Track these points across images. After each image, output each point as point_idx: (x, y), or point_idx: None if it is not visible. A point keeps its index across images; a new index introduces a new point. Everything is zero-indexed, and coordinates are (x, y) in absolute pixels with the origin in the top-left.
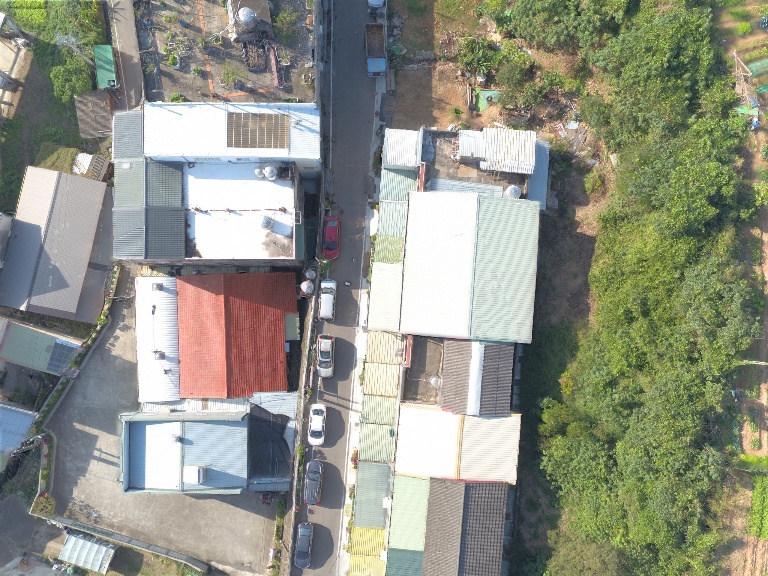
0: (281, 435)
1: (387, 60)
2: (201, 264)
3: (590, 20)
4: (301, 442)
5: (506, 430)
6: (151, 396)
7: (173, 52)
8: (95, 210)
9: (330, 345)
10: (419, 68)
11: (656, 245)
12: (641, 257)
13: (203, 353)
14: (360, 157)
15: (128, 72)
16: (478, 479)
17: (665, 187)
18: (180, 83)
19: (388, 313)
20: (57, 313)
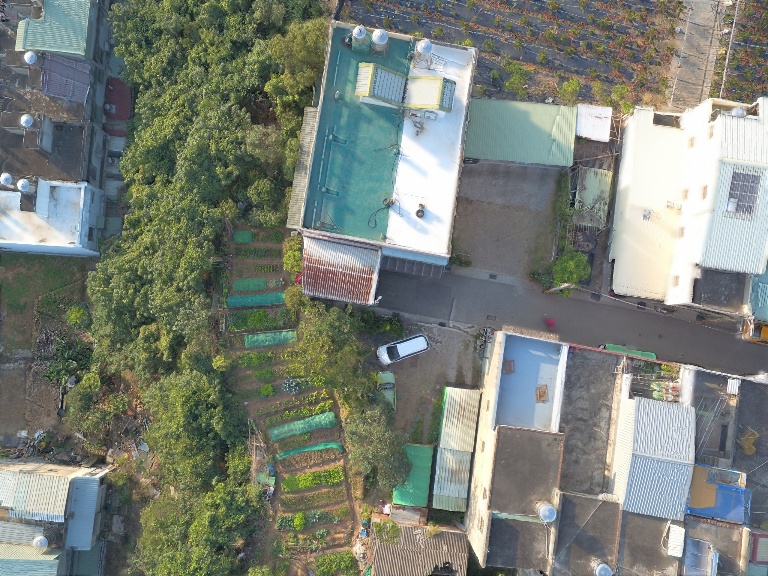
0: None
1: None
2: None
3: (139, 358)
4: None
5: None
6: None
7: None
8: None
9: None
10: (15, 368)
11: None
12: None
13: None
14: None
15: None
16: None
17: (150, 575)
18: None
19: None
20: None
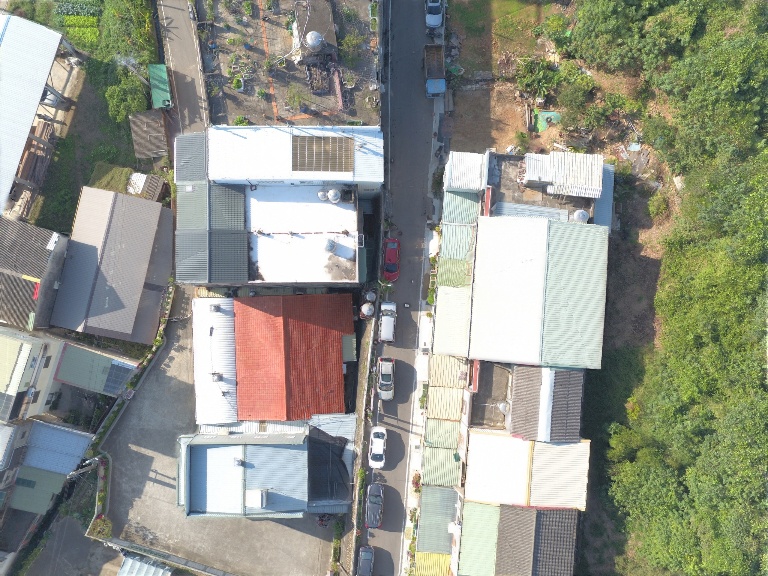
0: (340, 457)
1: (445, 80)
2: (259, 286)
3: (656, 43)
4: (361, 465)
5: (576, 456)
6: (209, 418)
7: (237, 75)
8: (151, 231)
9: (391, 368)
10: (477, 89)
11: (728, 271)
12: (711, 282)
13: (261, 375)
14: (419, 178)
15: (182, 91)
16: (548, 505)
17: (739, 214)
18: (244, 106)
19: (454, 337)
20: (113, 334)
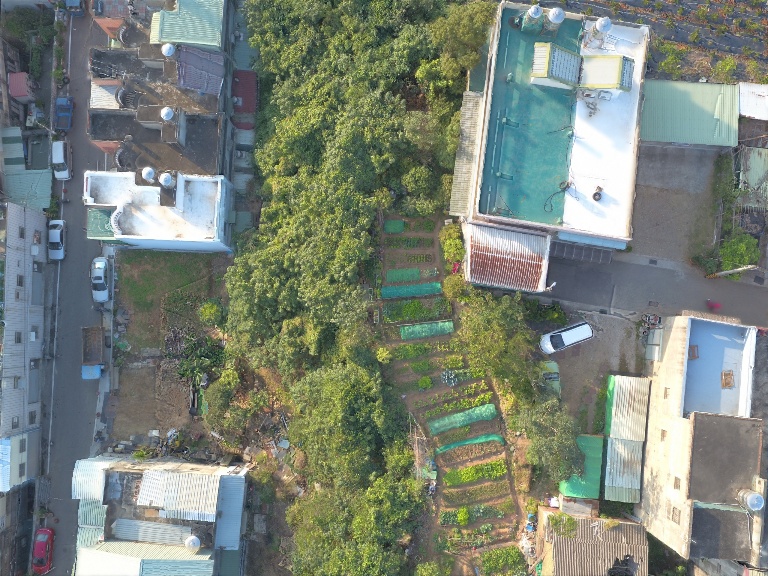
0: None
1: (112, 357)
2: None
3: (284, 353)
4: None
5: None
6: None
7: None
8: None
9: None
10: (143, 366)
11: None
12: None
13: None
14: None
15: None
16: None
17: (319, 573)
18: None
19: None
20: None
